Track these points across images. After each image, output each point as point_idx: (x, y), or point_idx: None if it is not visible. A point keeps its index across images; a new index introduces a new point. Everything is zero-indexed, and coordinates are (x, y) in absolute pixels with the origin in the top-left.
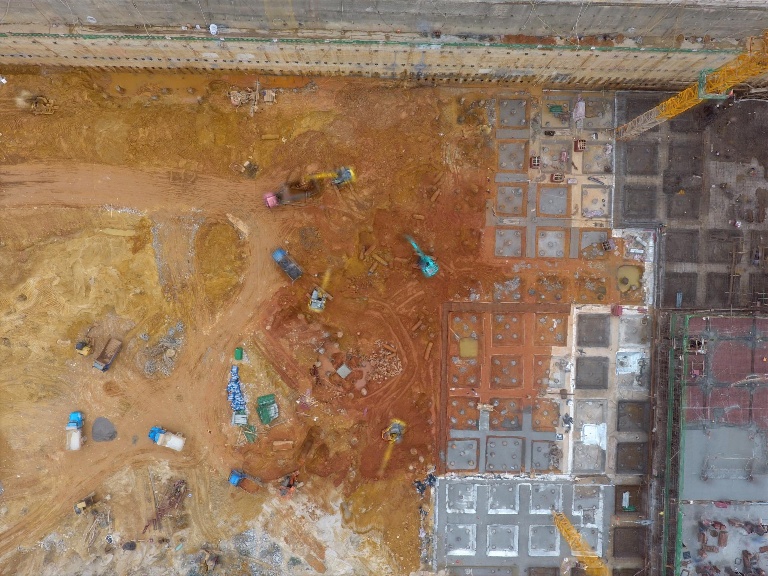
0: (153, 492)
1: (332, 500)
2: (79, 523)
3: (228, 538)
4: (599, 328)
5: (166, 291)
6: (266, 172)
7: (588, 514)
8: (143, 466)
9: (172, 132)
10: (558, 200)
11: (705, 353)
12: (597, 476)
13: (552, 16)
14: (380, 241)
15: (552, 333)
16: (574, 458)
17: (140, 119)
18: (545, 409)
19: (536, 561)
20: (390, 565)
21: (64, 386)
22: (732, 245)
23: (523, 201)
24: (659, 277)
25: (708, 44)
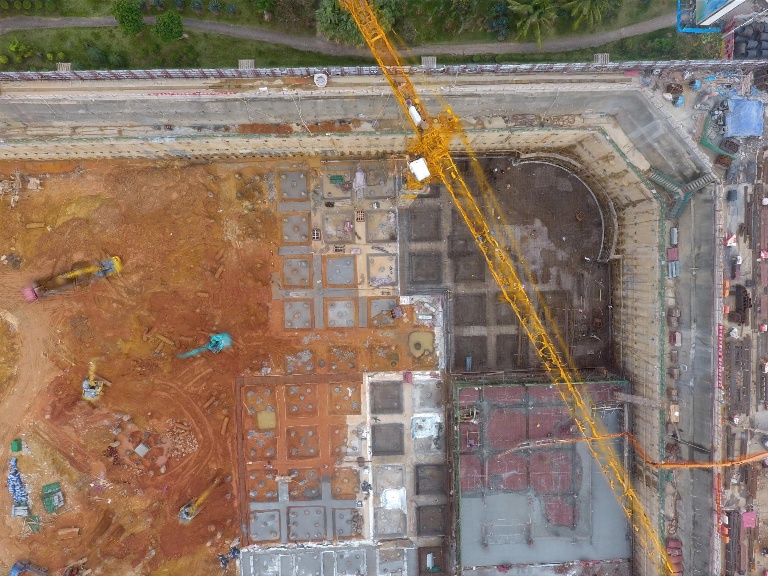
0: None
1: None
2: None
3: None
4: (394, 394)
5: None
6: (31, 262)
7: (396, 575)
8: None
9: None
10: (345, 270)
11: (478, 423)
12: (399, 540)
13: (271, 109)
14: (161, 322)
15: (347, 402)
16: (376, 523)
17: None
18: (345, 477)
19: None
20: None
21: None
22: (518, 307)
23: (310, 273)
24: (448, 342)
25: (446, 124)
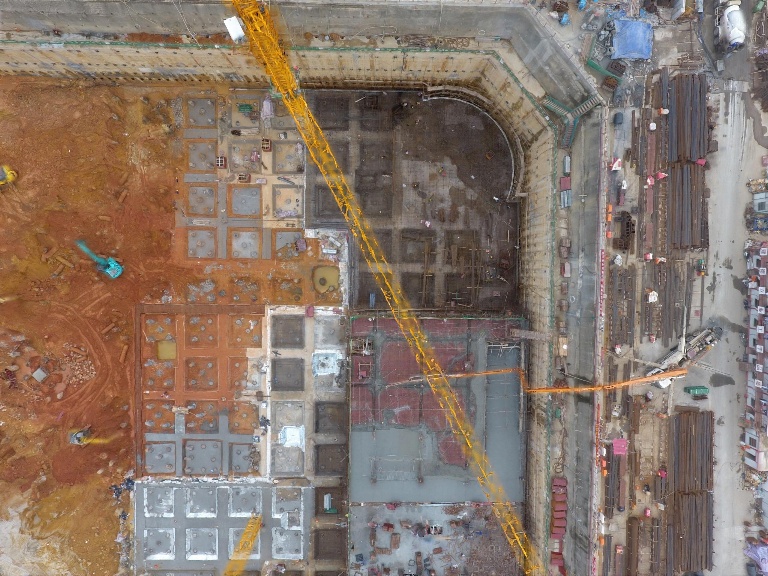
0: None
1: (13, 506)
2: None
3: None
4: (296, 329)
5: None
6: None
7: (293, 516)
8: None
9: None
10: (251, 200)
11: (370, 354)
12: (296, 478)
13: (154, 14)
14: (59, 243)
15: (249, 335)
16: (274, 460)
17: None
18: (244, 411)
19: (236, 564)
20: (72, 571)
21: None
22: (424, 245)
23: (215, 201)
24: (351, 277)
25: (338, 42)
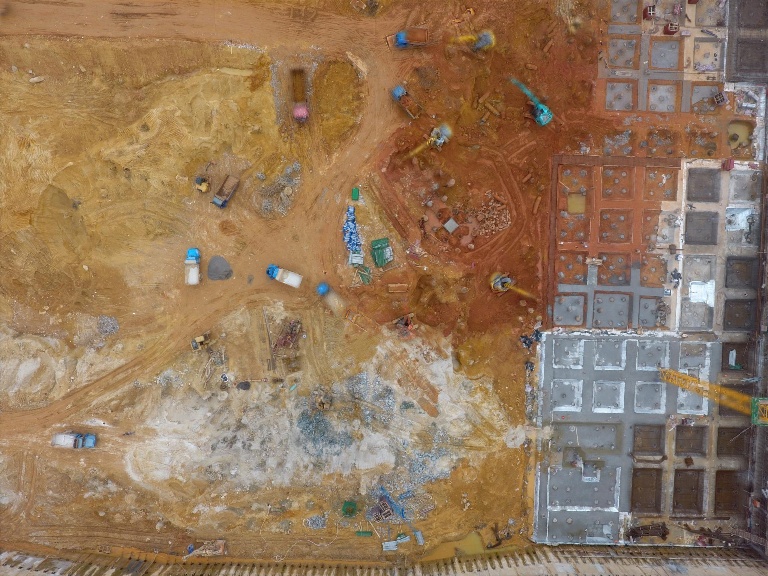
0: (268, 332)
1: (444, 347)
2: (194, 361)
3: (341, 381)
4: (708, 184)
5: (283, 130)
6: (386, 10)
7: (693, 374)
8: (258, 306)
9: None
10: (670, 54)
11: None
12: (704, 333)
13: None
14: (495, 88)
15: (661, 189)
16: (681, 315)
17: None
18: (653, 266)
19: (642, 418)
20: (501, 412)
21: (180, 225)
22: None
23: (635, 54)
24: None
25: None
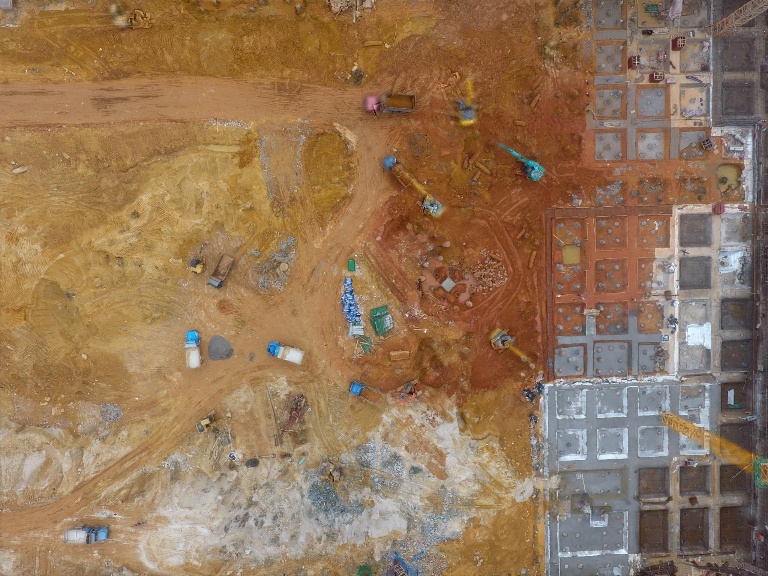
0: (273, 408)
1: (448, 409)
2: (201, 442)
3: (349, 450)
4: (700, 228)
5: (275, 205)
6: (372, 78)
7: (693, 414)
8: (261, 383)
9: (276, 40)
10: (656, 101)
11: None
12: (703, 375)
13: None
14: (484, 148)
15: (654, 236)
16: (679, 359)
17: (242, 28)
18: (649, 312)
19: (646, 462)
20: (509, 470)
21: (177, 306)
22: None
23: (622, 103)
24: (759, 173)
25: None
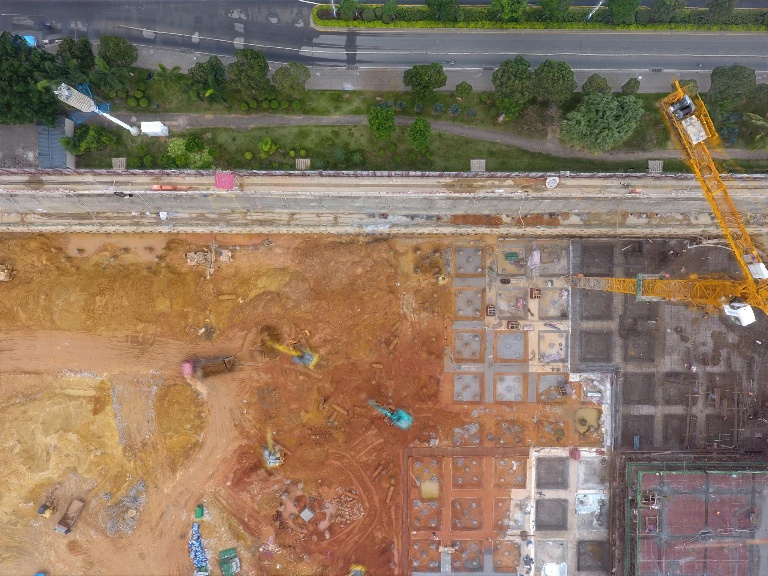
0: None
1: None
2: None
3: None
4: (558, 469)
5: (127, 451)
6: (223, 334)
7: None
8: None
9: (129, 299)
10: (515, 345)
11: (659, 509)
12: None
13: (495, 206)
14: (338, 393)
15: (512, 475)
16: None
17: (97, 286)
18: (506, 549)
19: None
20: None
21: (28, 546)
22: (688, 388)
23: (481, 347)
24: (616, 421)
25: (653, 219)
